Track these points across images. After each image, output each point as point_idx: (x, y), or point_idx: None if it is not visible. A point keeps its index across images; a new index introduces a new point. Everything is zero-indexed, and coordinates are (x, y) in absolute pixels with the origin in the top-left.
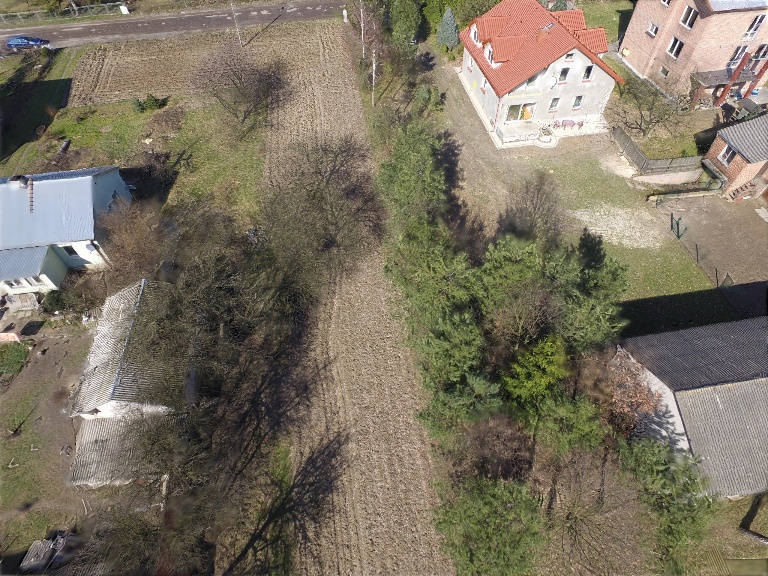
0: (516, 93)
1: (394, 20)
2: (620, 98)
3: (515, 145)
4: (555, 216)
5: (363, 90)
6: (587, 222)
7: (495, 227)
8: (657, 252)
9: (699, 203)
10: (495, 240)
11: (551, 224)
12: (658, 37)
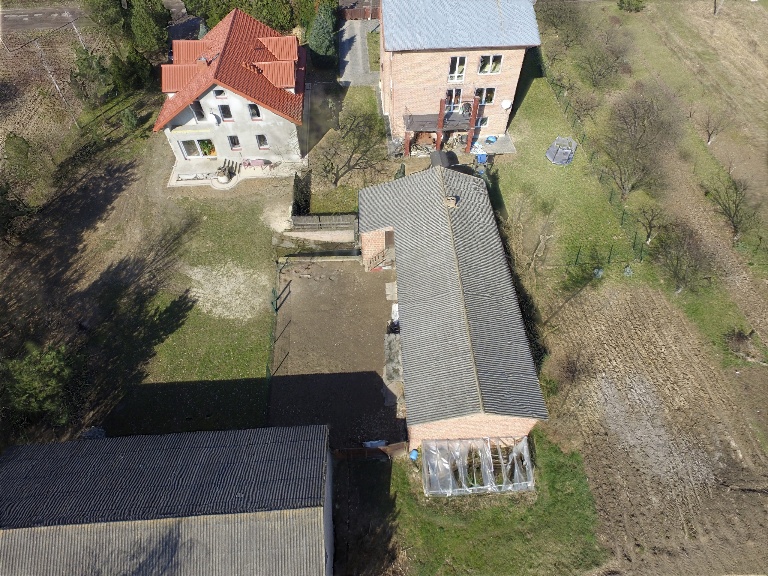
0: (183, 128)
1: (136, 34)
2: (343, 136)
3: (188, 184)
4: (167, 272)
5: (86, 109)
6: (195, 282)
7: (93, 279)
8: (240, 326)
9: (332, 269)
10: (81, 295)
11: (155, 281)
12: (383, 72)
